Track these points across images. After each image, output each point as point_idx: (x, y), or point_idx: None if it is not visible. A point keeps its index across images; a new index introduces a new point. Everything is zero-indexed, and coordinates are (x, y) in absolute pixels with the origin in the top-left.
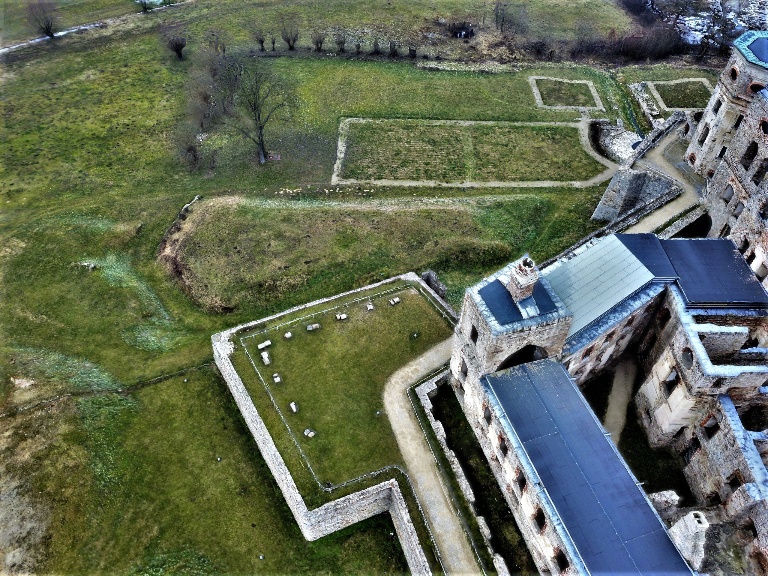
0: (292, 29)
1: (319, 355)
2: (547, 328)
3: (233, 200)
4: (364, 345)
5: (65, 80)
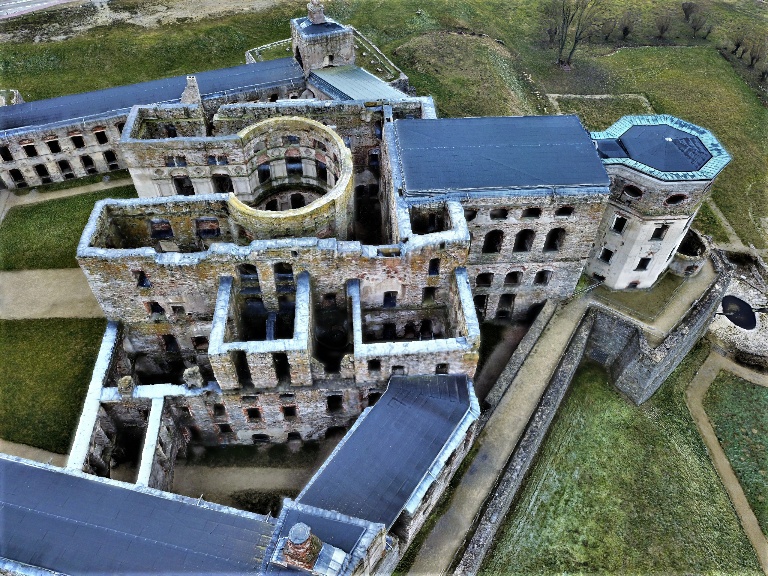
0: (763, 49)
1: None
2: None
3: (497, 49)
4: None
5: None
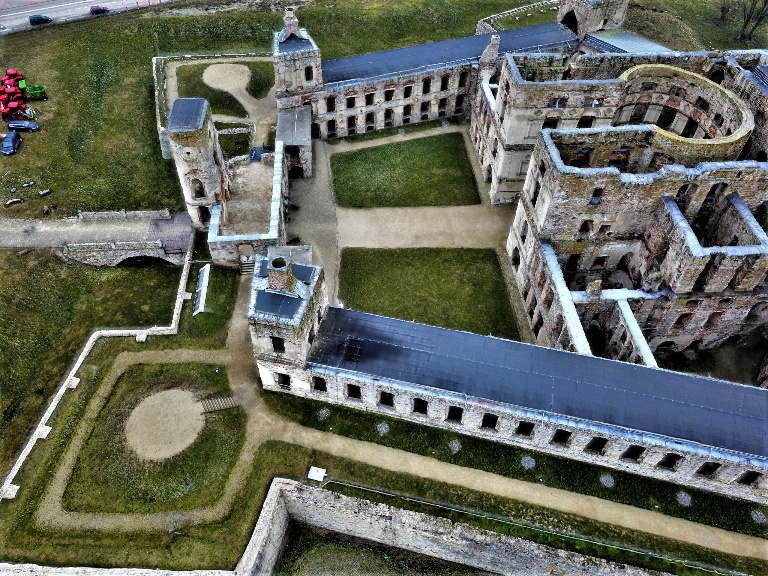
0: None
1: None
2: (581, 4)
3: None
4: None
5: None
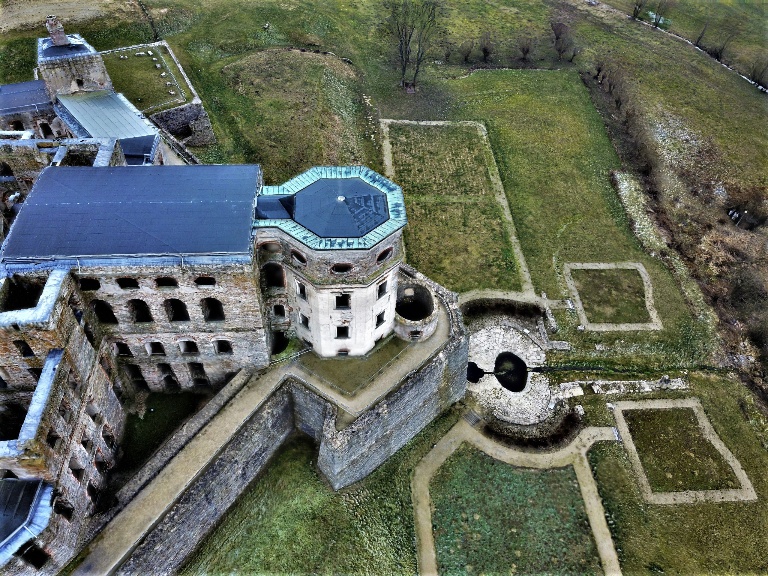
0: (618, 75)
1: (136, 69)
2: None
3: None
4: (138, 82)
5: (497, 3)
